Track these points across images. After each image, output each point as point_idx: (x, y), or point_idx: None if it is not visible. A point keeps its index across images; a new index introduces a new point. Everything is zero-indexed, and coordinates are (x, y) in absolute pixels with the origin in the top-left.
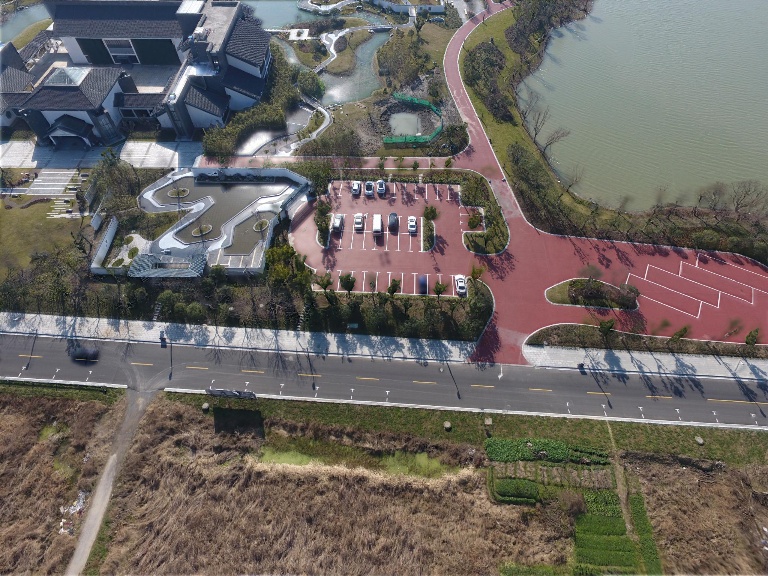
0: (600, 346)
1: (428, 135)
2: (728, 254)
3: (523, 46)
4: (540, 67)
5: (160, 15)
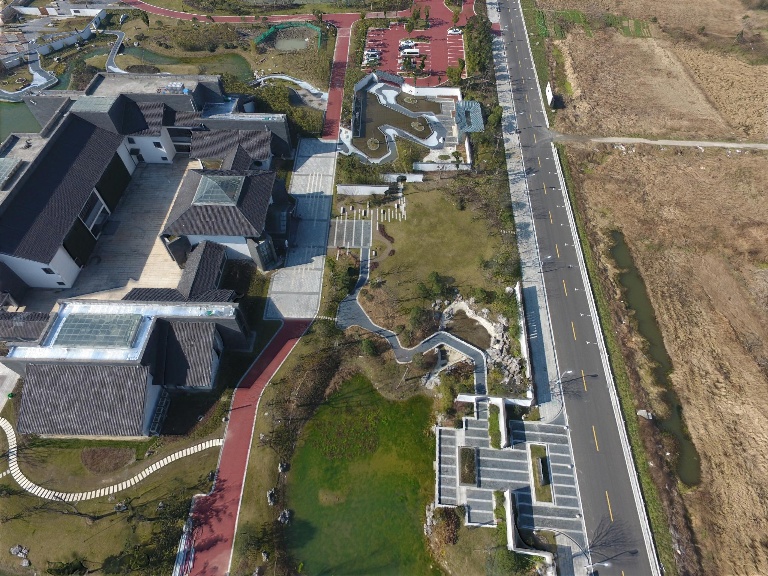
0: (485, 5)
1: None
2: None
3: None
4: None
5: (76, 143)
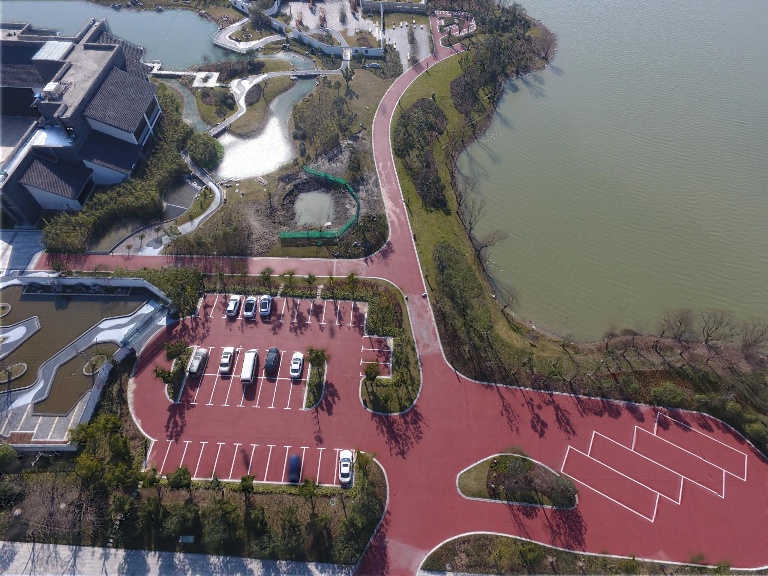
0: (521, 572)
1: (336, 229)
2: (694, 414)
3: (469, 104)
4: (487, 131)
5: (17, 58)
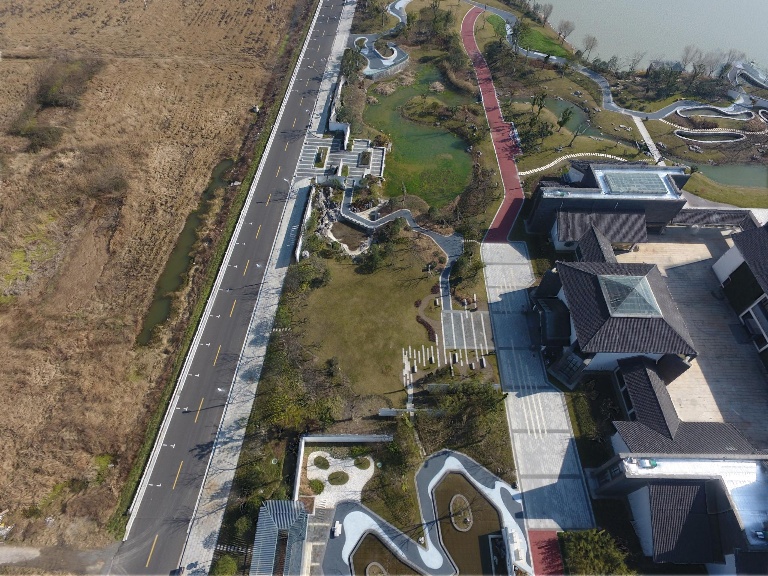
0: None
1: None
2: None
3: None
4: None
5: None
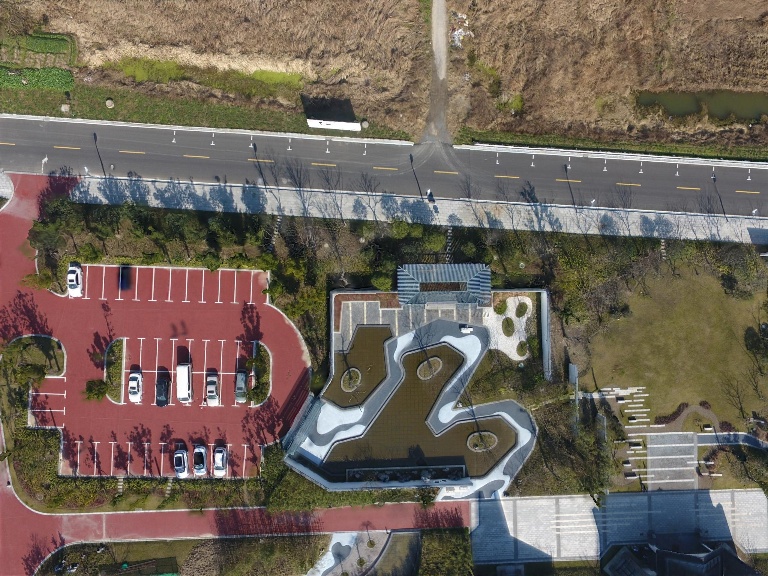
0: None
1: None
2: None
3: None
4: None
5: None
